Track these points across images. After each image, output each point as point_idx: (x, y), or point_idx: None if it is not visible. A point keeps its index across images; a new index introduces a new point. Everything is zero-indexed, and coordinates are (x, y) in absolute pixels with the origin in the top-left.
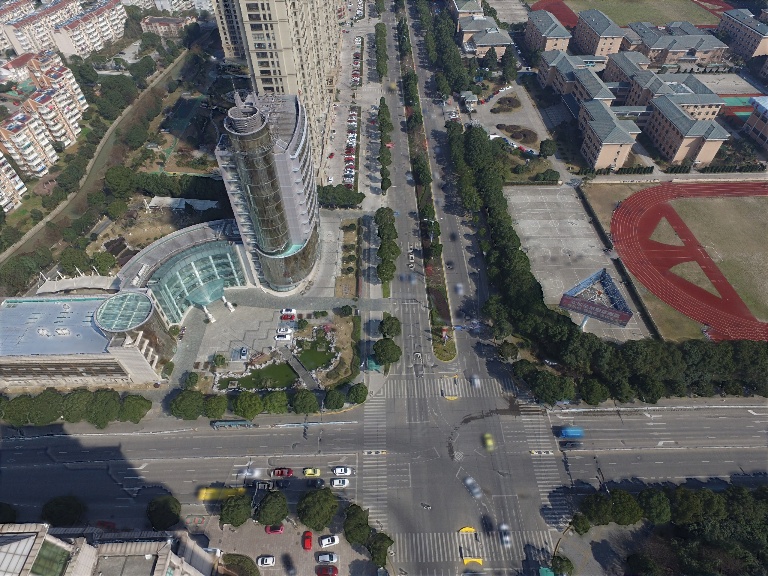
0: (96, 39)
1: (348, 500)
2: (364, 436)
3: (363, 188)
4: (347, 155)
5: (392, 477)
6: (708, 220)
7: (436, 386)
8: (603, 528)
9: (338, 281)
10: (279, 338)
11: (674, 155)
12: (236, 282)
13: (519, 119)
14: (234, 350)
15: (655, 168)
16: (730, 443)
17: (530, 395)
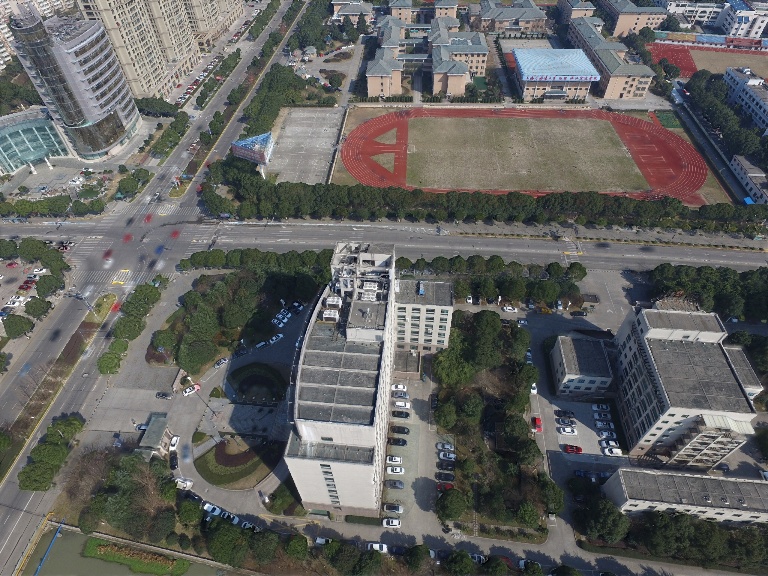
0: (46, 7)
1: (63, 256)
2: (94, 230)
3: (189, 106)
4: (190, 85)
5: (97, 248)
6: (427, 130)
7: (157, 209)
8: (208, 273)
9: (132, 156)
10: (71, 182)
11: (433, 89)
12: (60, 153)
13: (341, 67)
14: (40, 188)
15: (418, 99)
16: (325, 242)
17: (215, 215)
